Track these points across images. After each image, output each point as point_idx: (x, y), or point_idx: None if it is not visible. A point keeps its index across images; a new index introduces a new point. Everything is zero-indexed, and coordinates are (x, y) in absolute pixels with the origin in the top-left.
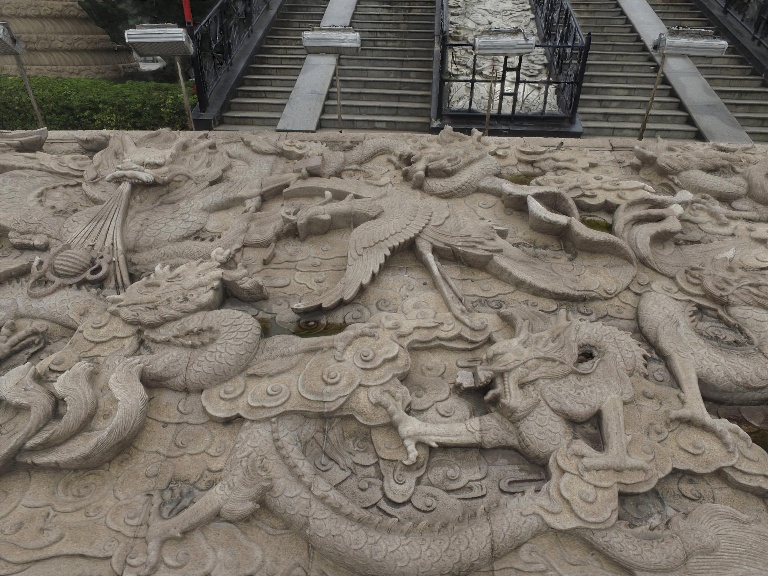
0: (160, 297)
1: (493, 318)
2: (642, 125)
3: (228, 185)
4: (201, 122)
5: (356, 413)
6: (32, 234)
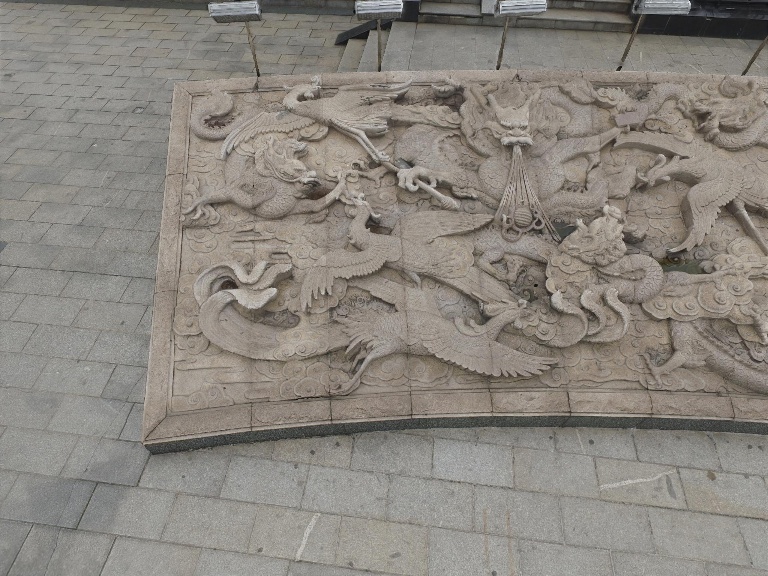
0: (599, 247)
1: None
2: None
3: (576, 142)
4: (408, 4)
5: (731, 318)
6: (466, 188)
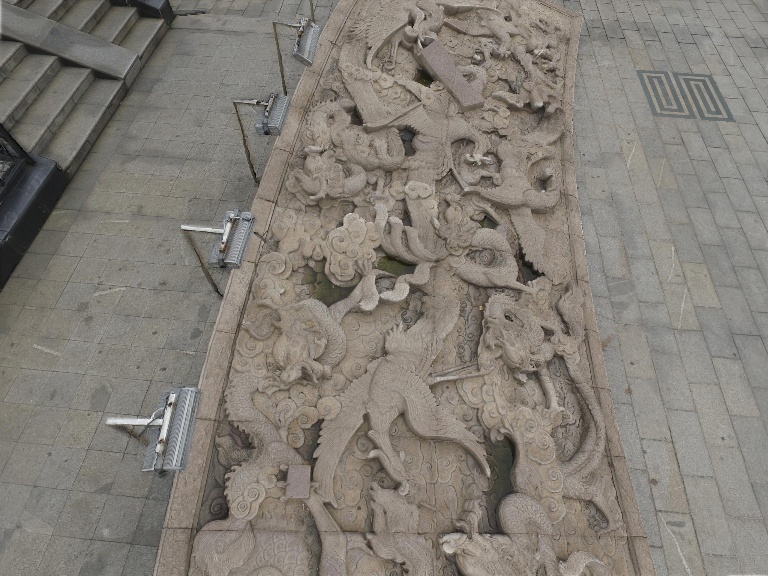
0: (510, 575)
1: (486, 354)
2: (251, 167)
3: (333, 573)
4: None
5: None
6: None
